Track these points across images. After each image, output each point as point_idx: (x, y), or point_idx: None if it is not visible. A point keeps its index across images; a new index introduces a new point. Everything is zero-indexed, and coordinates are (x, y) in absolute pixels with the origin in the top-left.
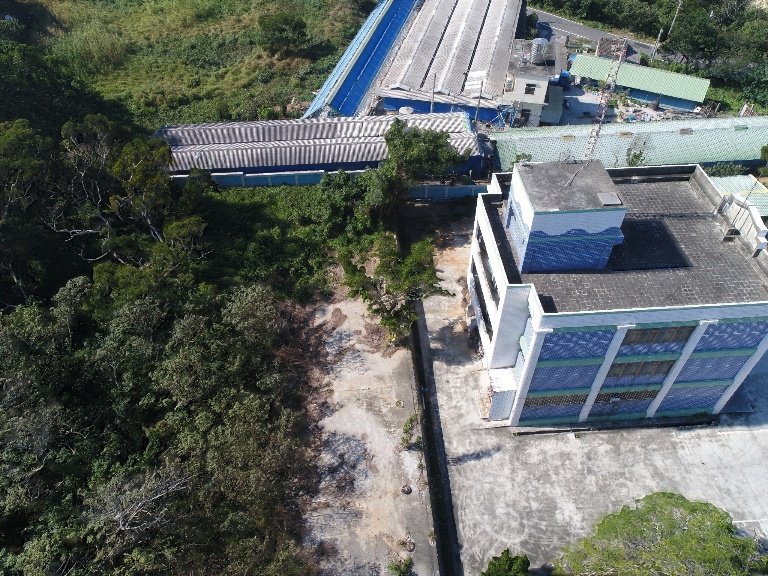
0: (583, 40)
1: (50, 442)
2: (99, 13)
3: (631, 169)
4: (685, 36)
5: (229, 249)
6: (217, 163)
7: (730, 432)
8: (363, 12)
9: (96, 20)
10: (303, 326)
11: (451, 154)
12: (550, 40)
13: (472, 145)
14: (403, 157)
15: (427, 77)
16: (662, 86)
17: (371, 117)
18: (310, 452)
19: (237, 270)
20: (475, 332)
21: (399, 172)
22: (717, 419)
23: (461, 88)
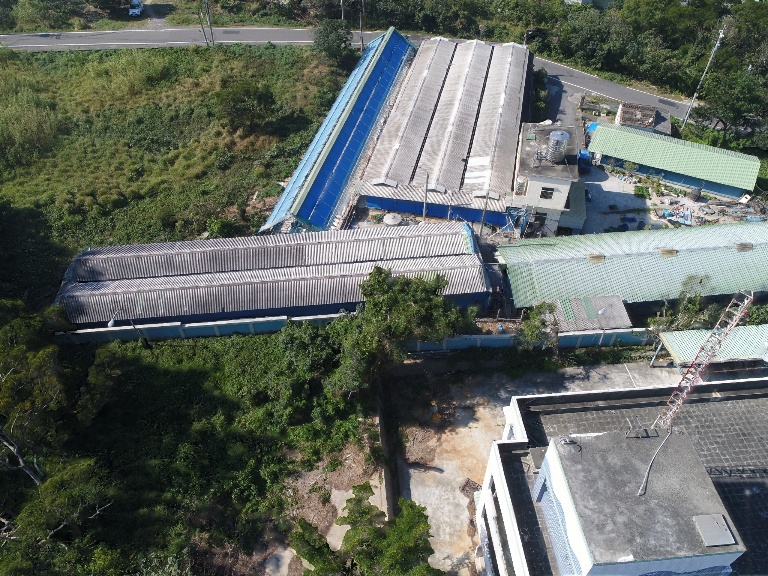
0: (600, 99)
1: None
2: (32, 78)
3: (711, 385)
4: (724, 102)
5: (152, 456)
6: (147, 310)
7: None
8: (343, 69)
9: (26, 88)
10: None
11: (450, 319)
12: (561, 99)
13: (476, 277)
14: (385, 329)
15: (418, 166)
16: (702, 168)
17: (348, 232)
18: None
19: (161, 490)
20: None
21: (381, 341)
22: None
23: (460, 182)
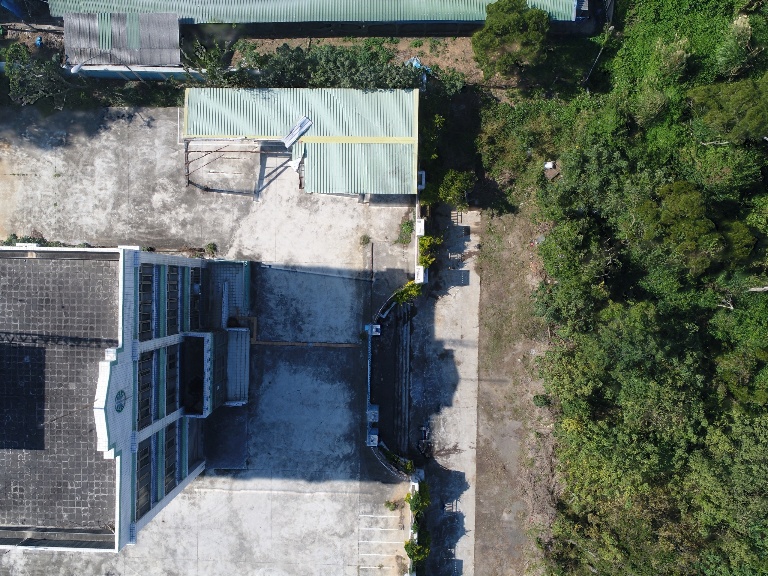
0: None
1: None
2: None
3: (14, 249)
4: None
5: None
6: None
7: (208, 490)
8: None
9: None
10: None
11: None
12: None
13: None
14: None
15: None
16: None
17: None
18: None
19: None
20: None
21: None
22: (201, 474)
23: None
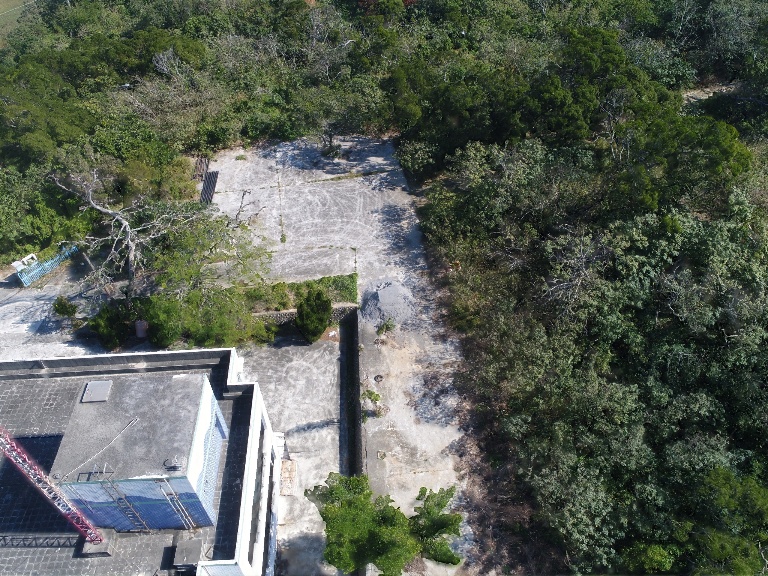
0: None
1: (697, 356)
2: None
3: None
4: None
5: None
6: None
7: None
8: None
9: None
10: (510, 567)
11: None
12: None
13: None
14: None
15: None
16: None
17: None
18: (467, 406)
19: None
20: (275, 575)
21: None
22: None
23: None
